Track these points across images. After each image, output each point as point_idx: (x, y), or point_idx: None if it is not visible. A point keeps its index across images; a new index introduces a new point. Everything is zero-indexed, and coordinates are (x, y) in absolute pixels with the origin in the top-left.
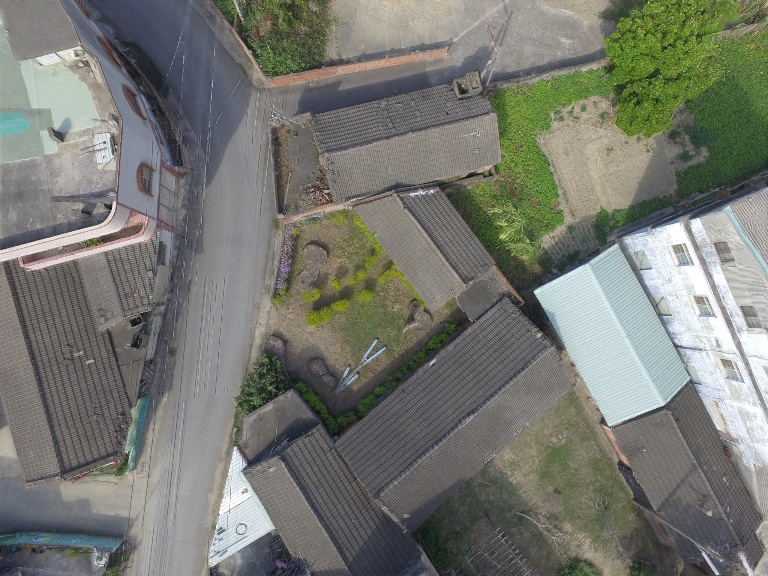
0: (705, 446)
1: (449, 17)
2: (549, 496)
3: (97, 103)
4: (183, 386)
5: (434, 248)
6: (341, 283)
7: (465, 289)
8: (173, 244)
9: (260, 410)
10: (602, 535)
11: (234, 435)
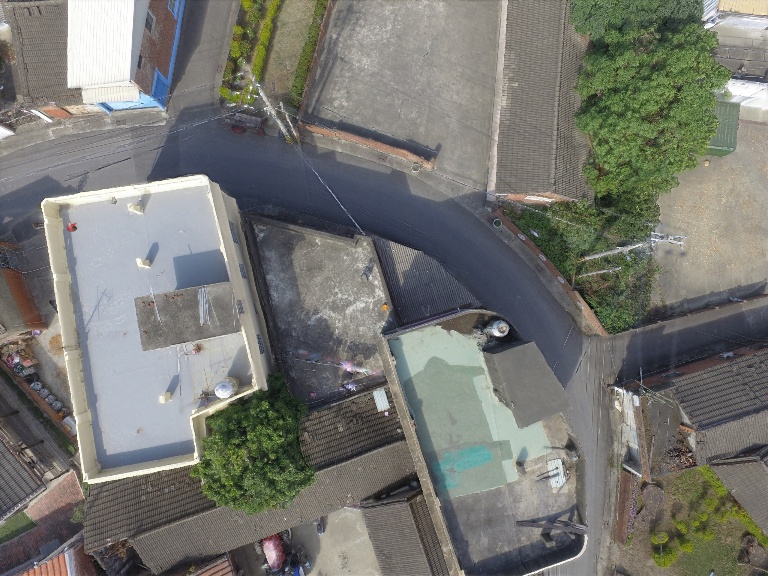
0: None
1: (763, 259)
2: None
3: (548, 432)
4: None
5: None
6: (677, 519)
7: None
8: None
9: None
10: None
11: None
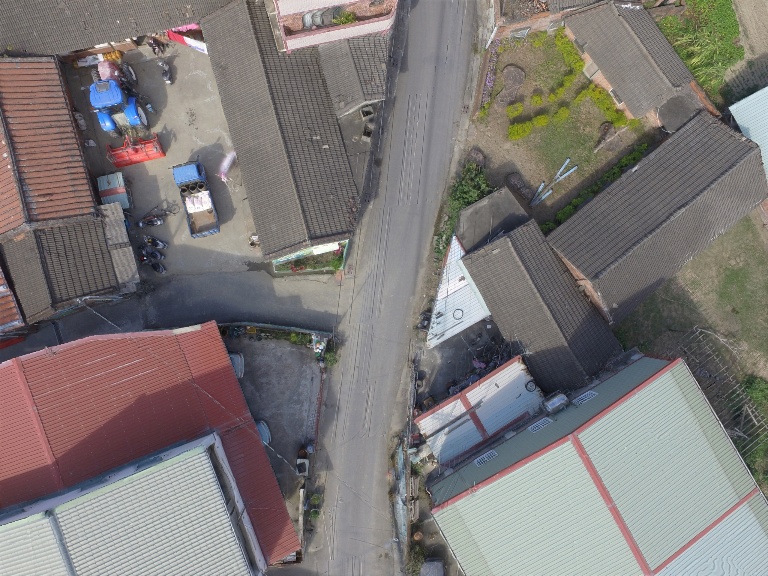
0: None
1: None
2: (727, 315)
3: None
4: (388, 195)
5: (646, 54)
6: None
7: (674, 94)
8: None
9: (476, 204)
10: None
11: (435, 242)
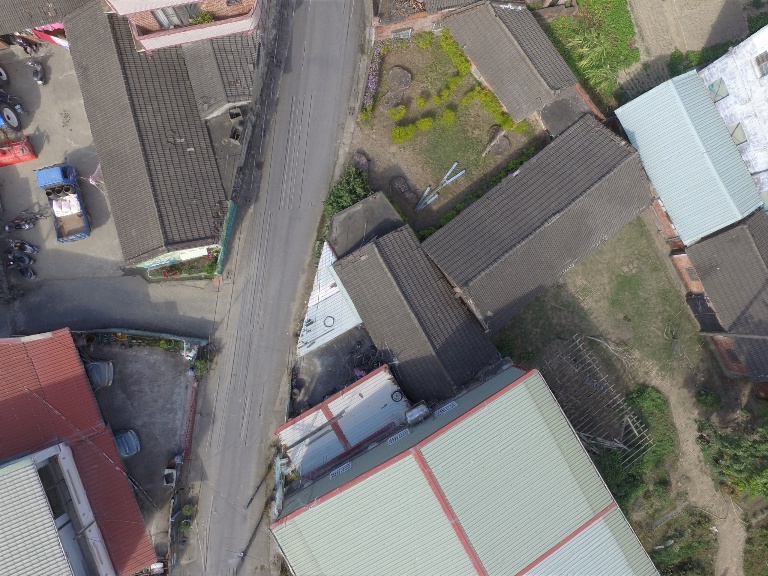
0: None
1: None
2: (619, 323)
3: None
4: (269, 198)
5: (523, 56)
6: None
7: (552, 97)
8: (263, 61)
9: (350, 209)
10: (669, 364)
11: (317, 247)
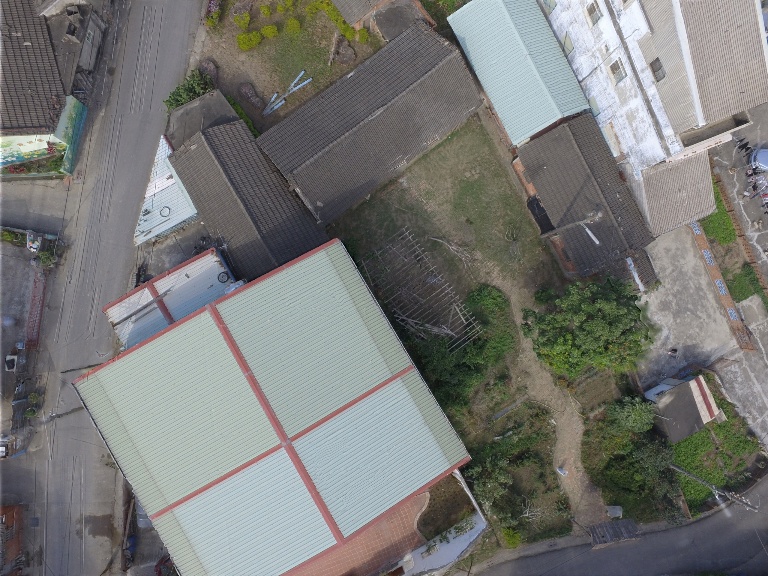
0: (601, 164)
1: None
2: (461, 225)
3: None
4: (120, 103)
5: None
6: (272, 18)
7: None
8: None
9: (187, 105)
10: (510, 265)
11: None
